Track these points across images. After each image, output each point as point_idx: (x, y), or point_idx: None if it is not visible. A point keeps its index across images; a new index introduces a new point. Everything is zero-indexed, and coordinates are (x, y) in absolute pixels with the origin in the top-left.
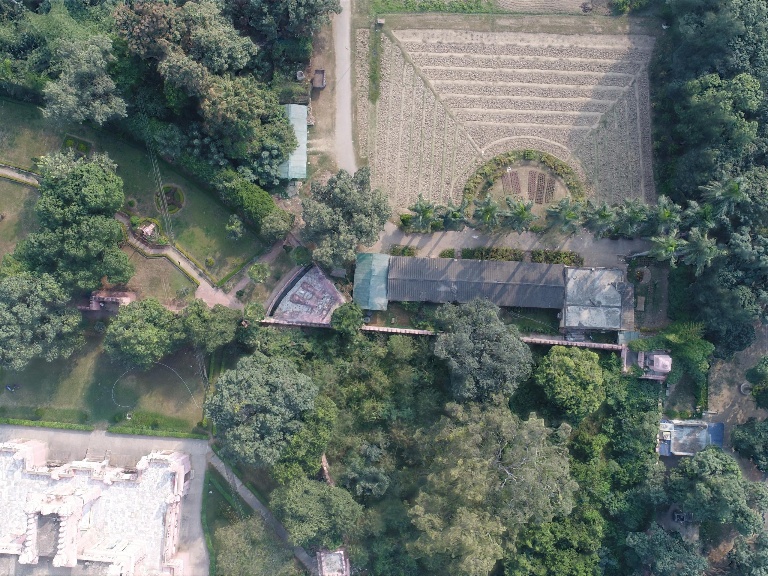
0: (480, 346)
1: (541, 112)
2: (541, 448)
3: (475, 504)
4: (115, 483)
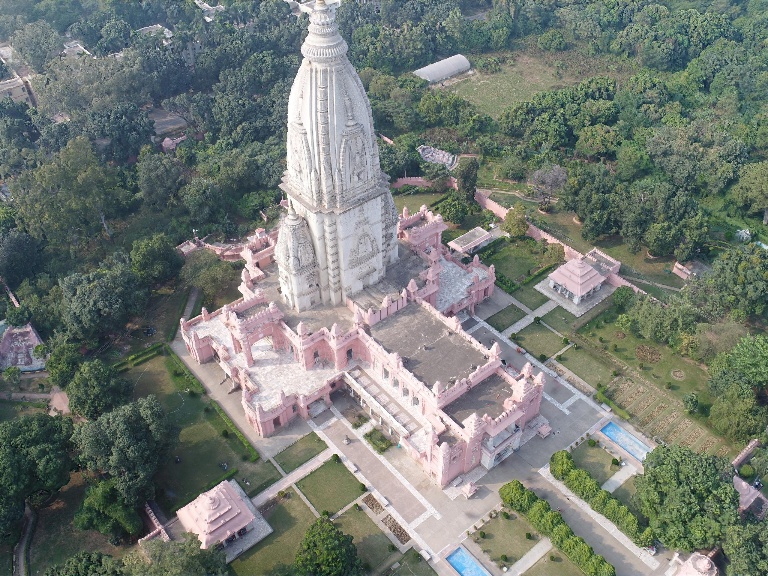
0: None
1: None
2: None
3: None
4: None
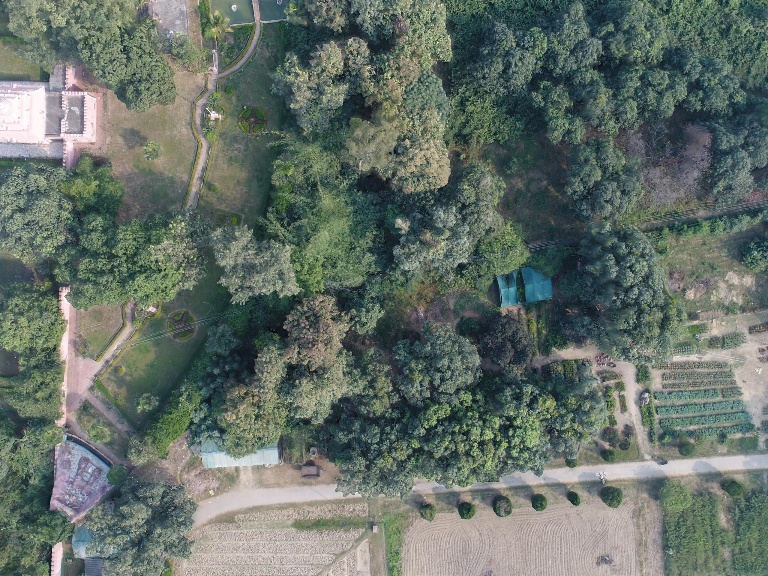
0: None
1: None
2: None
3: None
4: None
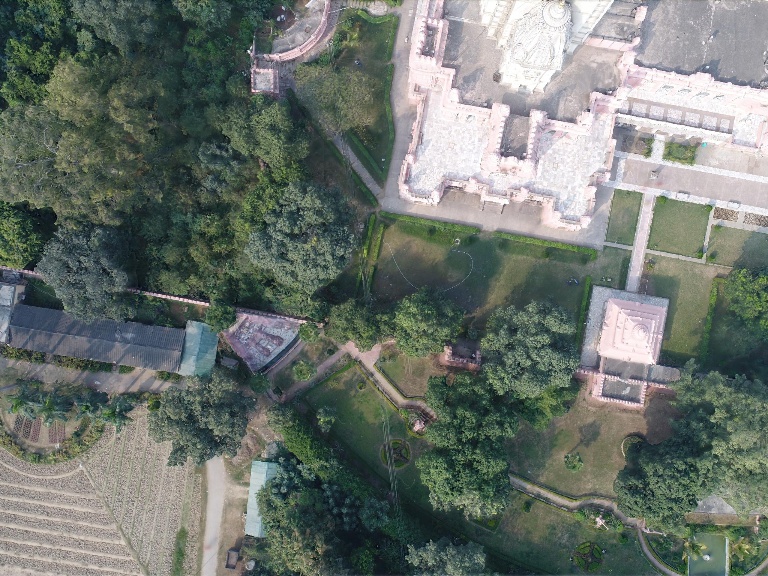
0: (78, 277)
1: (20, 500)
2: (1, 176)
3: (78, 128)
4: (468, 179)
